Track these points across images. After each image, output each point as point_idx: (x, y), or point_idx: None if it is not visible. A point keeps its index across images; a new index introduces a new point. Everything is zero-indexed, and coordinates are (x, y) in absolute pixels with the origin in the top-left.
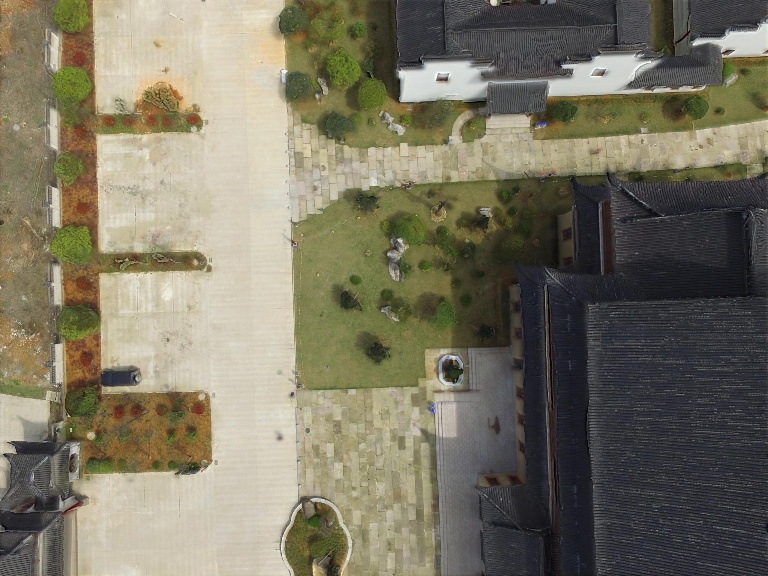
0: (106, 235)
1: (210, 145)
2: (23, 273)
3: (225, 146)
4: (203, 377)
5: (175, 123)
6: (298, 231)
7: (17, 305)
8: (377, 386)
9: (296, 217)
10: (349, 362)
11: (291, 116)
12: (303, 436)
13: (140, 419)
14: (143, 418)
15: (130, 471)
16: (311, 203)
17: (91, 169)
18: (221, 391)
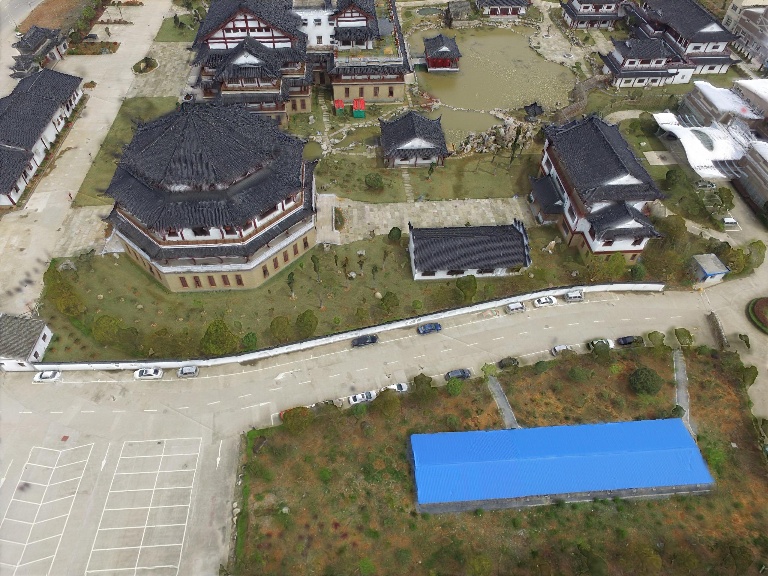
0: (102, 19)
1: (144, 8)
2: (69, 25)
3: (149, 8)
4: (121, 40)
5: (135, 4)
6: (167, 19)
7: (63, 30)
8: (182, 41)
9: (167, 17)
10: (174, 37)
11: (173, 4)
12: (151, 49)
13: (94, 45)
14: (95, 45)
15: (84, 54)
16: (173, 15)
17: (103, 10)
18: (126, 42)
